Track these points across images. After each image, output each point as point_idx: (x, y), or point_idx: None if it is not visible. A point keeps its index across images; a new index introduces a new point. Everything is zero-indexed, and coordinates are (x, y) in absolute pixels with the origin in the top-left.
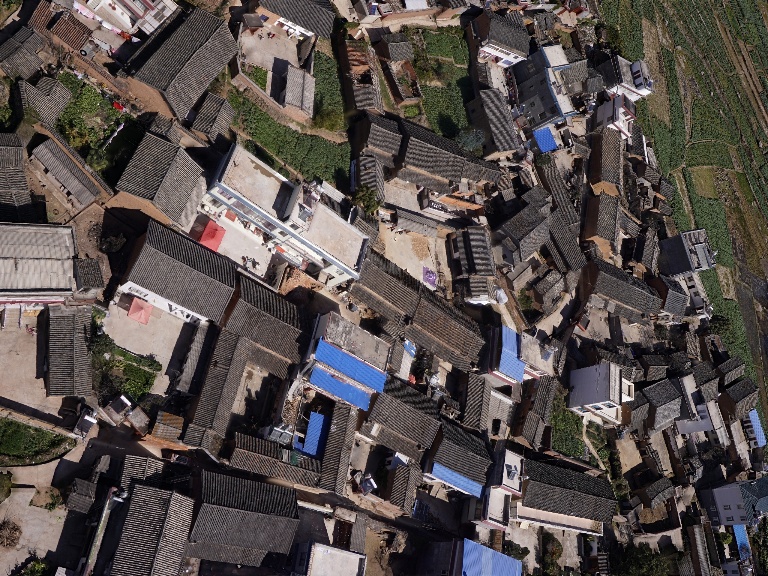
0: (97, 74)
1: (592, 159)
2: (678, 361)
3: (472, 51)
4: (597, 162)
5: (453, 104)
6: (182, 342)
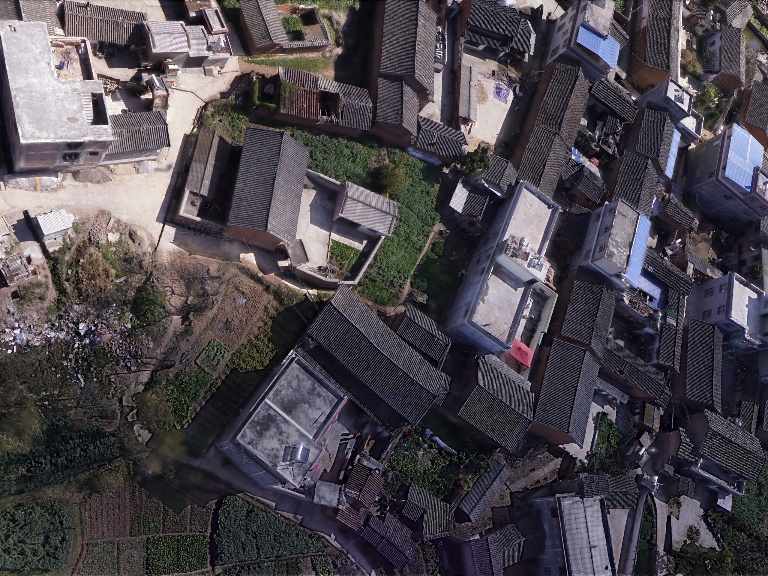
0: None
1: None
2: None
3: None
4: None
5: None
6: None
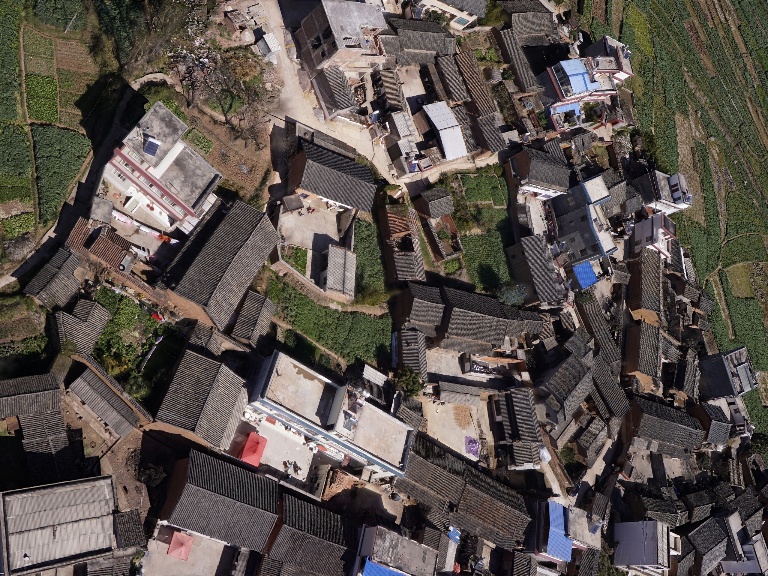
0: (135, 286)
1: (631, 282)
2: (722, 495)
3: (511, 190)
4: (636, 286)
5: (493, 251)
6: (222, 568)
